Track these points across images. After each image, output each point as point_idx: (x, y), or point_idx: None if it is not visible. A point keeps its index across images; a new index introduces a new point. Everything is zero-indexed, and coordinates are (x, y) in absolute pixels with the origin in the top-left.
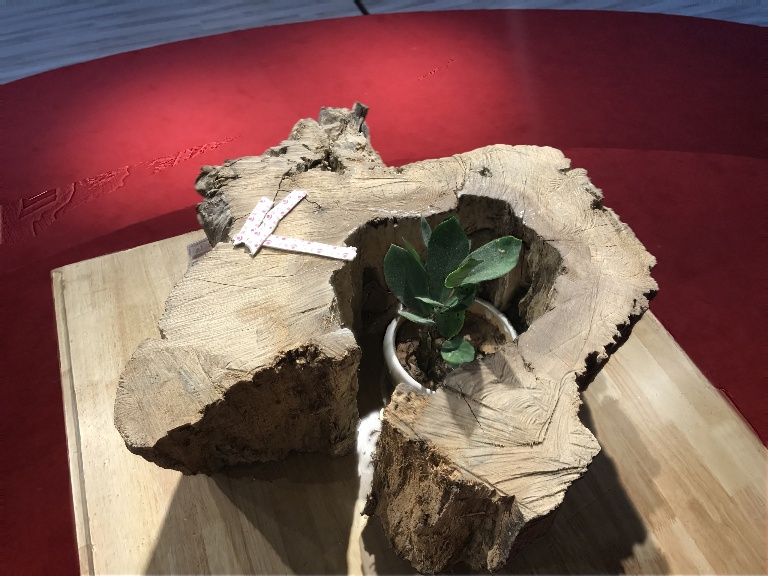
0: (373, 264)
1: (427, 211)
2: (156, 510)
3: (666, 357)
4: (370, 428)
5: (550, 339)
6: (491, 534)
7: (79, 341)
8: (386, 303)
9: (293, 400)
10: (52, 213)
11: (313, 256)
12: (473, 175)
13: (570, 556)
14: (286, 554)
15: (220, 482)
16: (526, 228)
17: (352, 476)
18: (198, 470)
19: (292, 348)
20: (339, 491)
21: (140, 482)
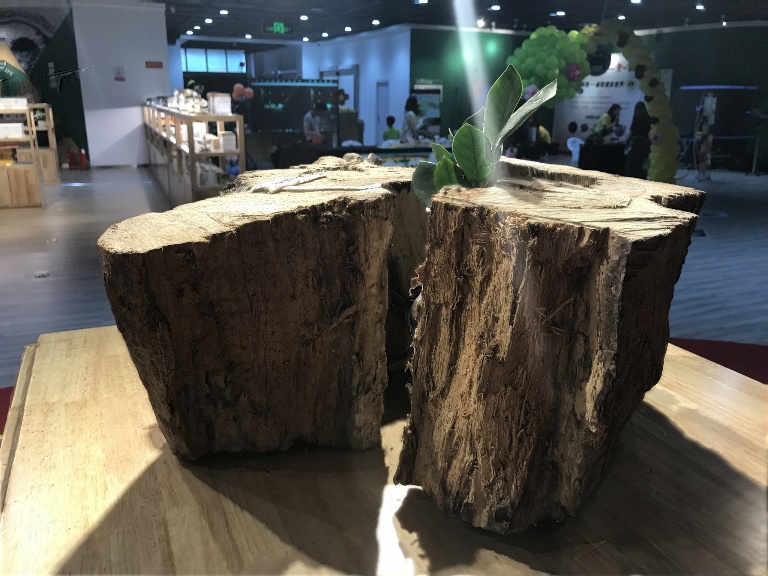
0: (394, 251)
1: None
2: (104, 496)
3: (736, 382)
4: (397, 430)
5: None
6: (585, 360)
7: (43, 376)
8: (405, 344)
9: (311, 298)
10: (84, 69)
11: (336, 190)
12: None
13: (698, 530)
14: (287, 533)
15: (198, 472)
16: (553, 174)
17: (377, 466)
18: (177, 409)
19: (317, 204)
20: (360, 479)
21: (88, 474)
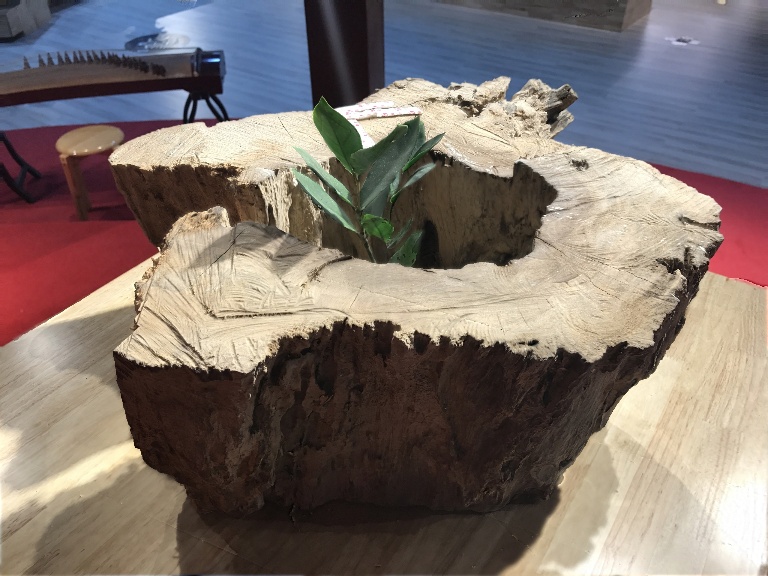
0: (434, 218)
1: (484, 168)
2: None
3: None
4: None
5: (378, 282)
6: None
7: None
8: None
9: None
10: None
11: None
12: (560, 157)
13: None
14: None
15: None
16: None
17: None
18: None
19: (236, 166)
20: None
21: None
